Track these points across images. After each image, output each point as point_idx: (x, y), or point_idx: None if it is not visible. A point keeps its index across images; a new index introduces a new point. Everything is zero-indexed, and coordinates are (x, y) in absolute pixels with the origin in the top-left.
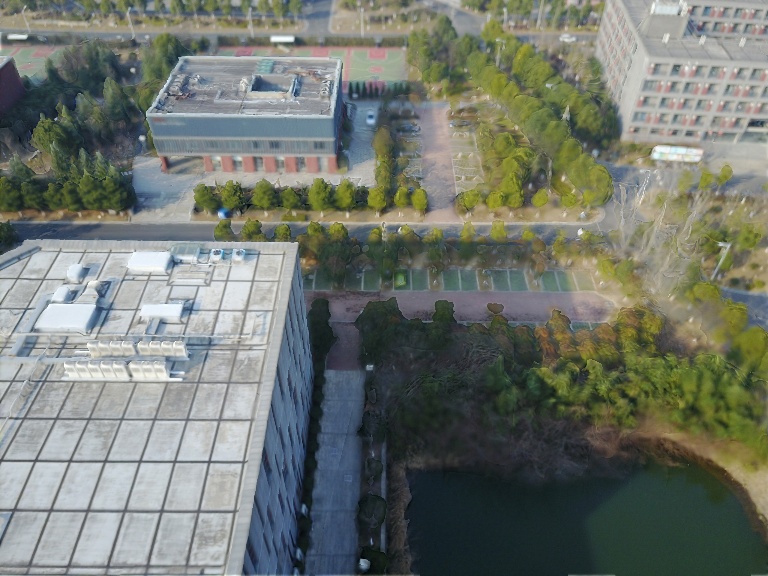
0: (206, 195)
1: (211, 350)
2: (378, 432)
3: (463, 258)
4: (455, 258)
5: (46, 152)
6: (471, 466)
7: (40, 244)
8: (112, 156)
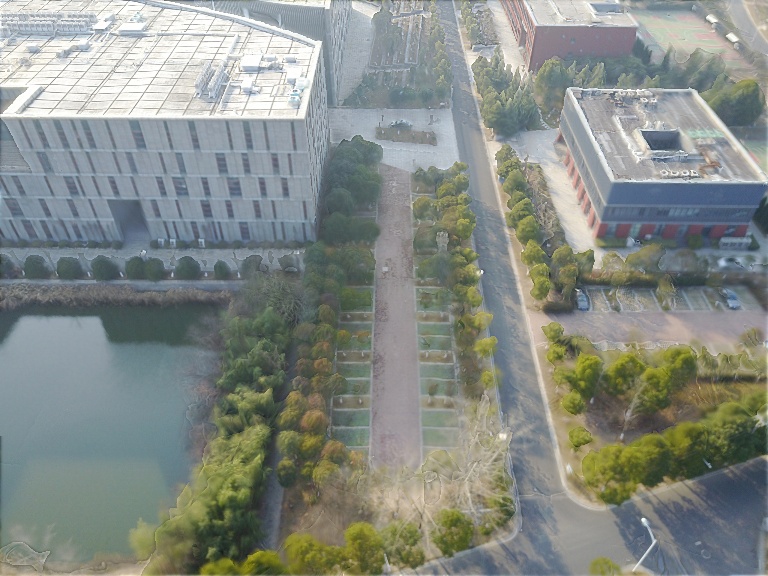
0: (502, 154)
1: (215, 103)
2: (247, 268)
3: None
4: None
5: None
6: None
7: (317, 45)
8: None
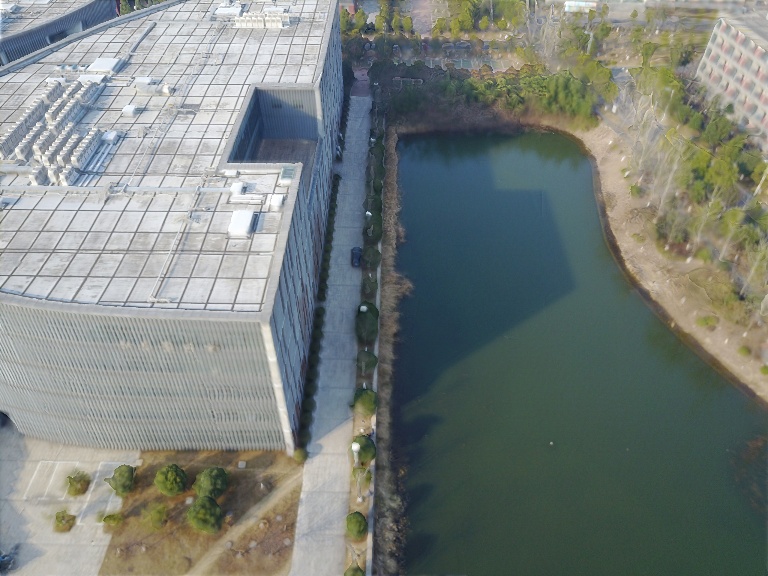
0: None
1: (300, 22)
2: (380, 111)
3: (434, 53)
4: (429, 54)
5: None
6: (432, 132)
7: None
8: None
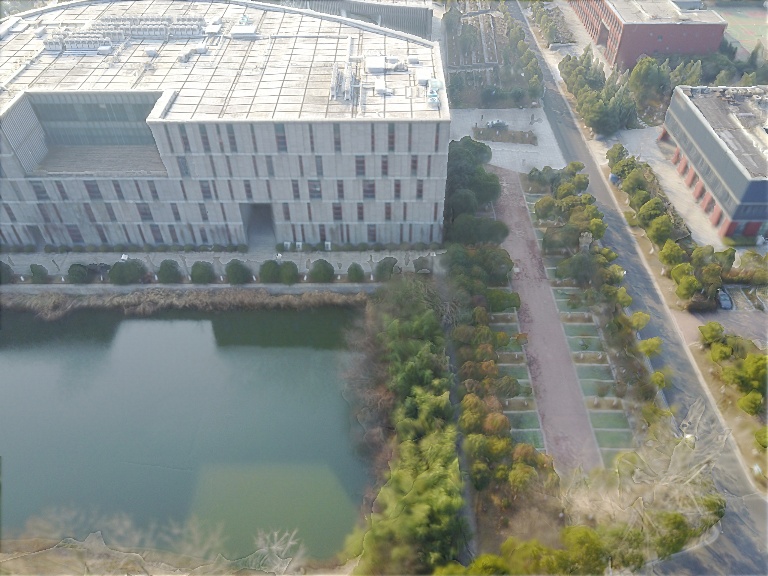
0: (614, 153)
1: (353, 106)
2: (382, 271)
3: (612, 334)
4: None
5: None
6: None
7: (435, 46)
8: (662, 113)
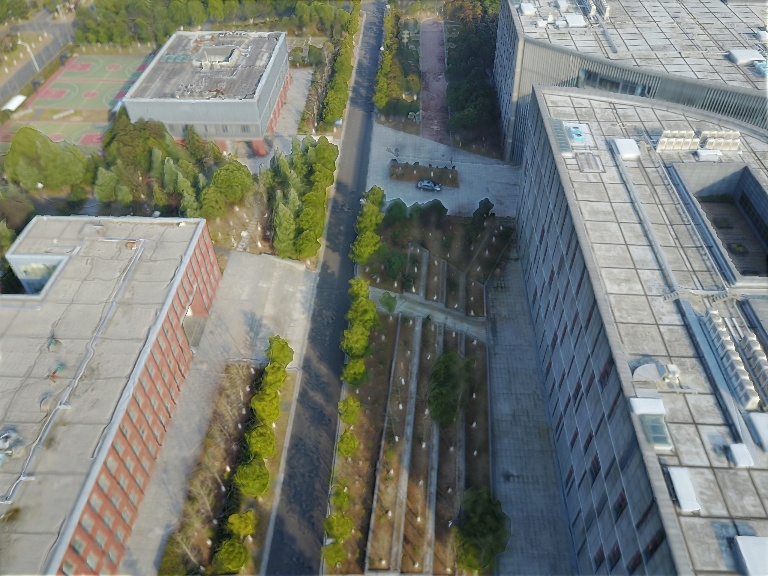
0: None
1: None
2: None
3: None
4: None
5: None
6: None
7: None
8: None
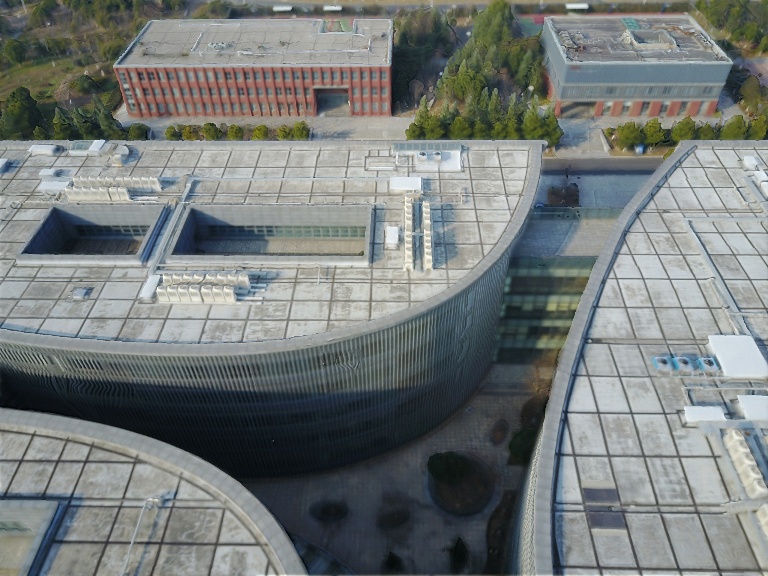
0: (635, 131)
1: None
2: None
3: None
4: None
5: (438, 102)
6: None
7: (696, 143)
8: None
